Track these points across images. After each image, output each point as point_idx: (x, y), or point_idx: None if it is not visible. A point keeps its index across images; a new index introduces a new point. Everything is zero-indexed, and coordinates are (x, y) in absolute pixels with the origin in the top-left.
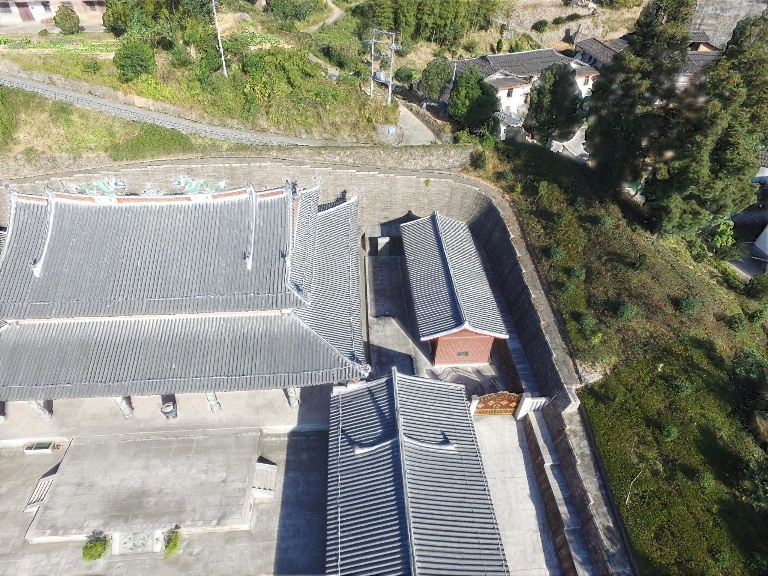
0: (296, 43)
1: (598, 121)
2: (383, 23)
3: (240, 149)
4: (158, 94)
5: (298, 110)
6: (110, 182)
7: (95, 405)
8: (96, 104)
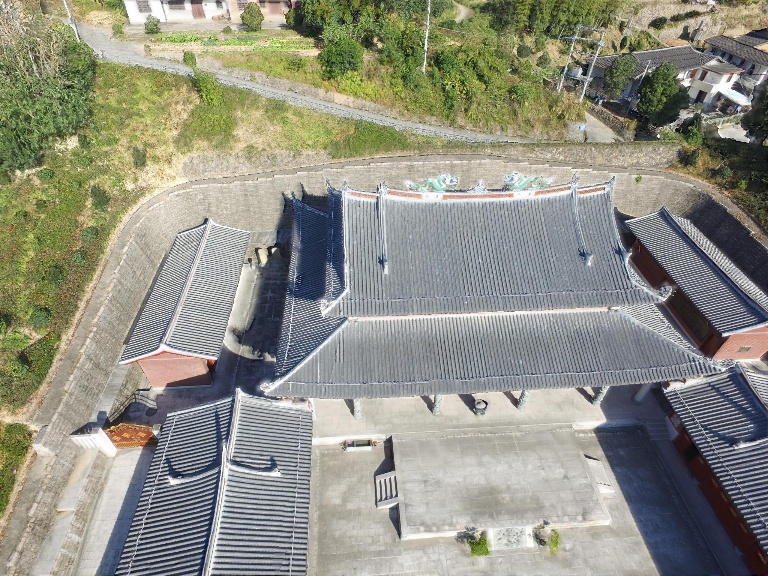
0: (461, 40)
1: None
2: (520, 20)
3: (456, 146)
4: (361, 91)
5: (495, 107)
6: (447, 179)
7: (396, 402)
8: (304, 101)
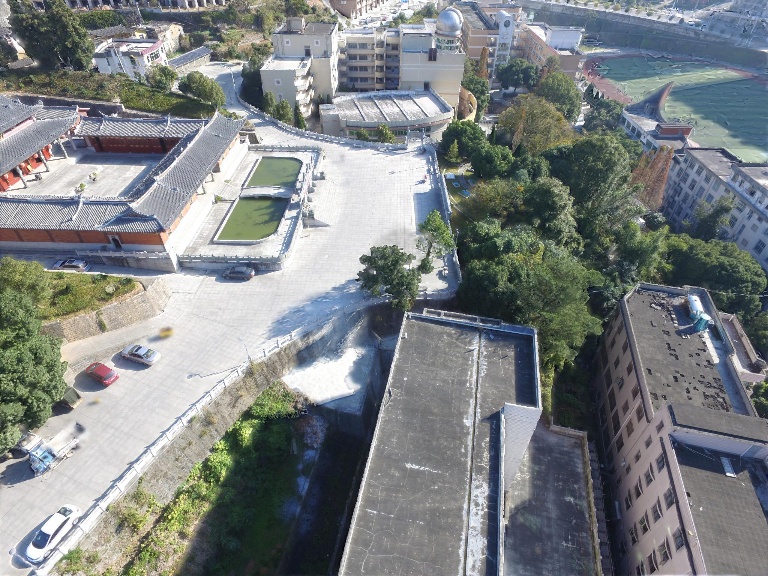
0: None
1: (28, 43)
2: None
3: None
4: None
5: None
6: None
7: None
8: None
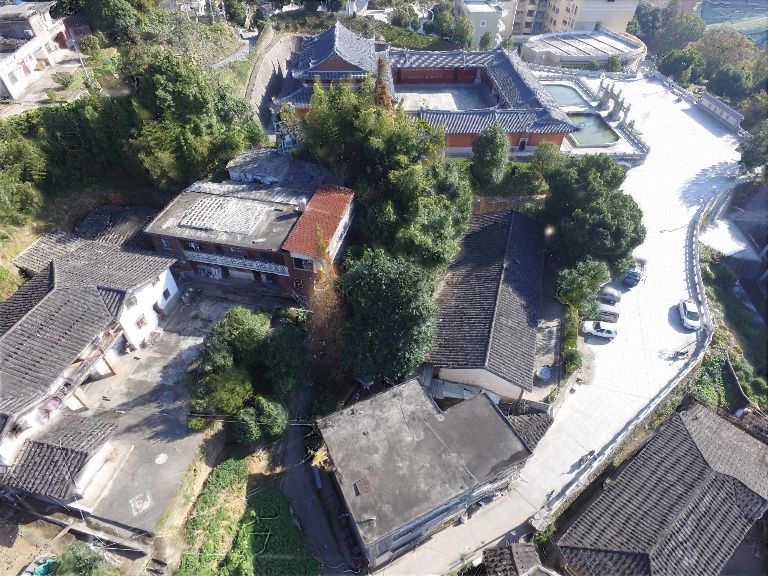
0: None
1: None
2: None
3: None
4: None
5: None
6: None
7: None
8: None
